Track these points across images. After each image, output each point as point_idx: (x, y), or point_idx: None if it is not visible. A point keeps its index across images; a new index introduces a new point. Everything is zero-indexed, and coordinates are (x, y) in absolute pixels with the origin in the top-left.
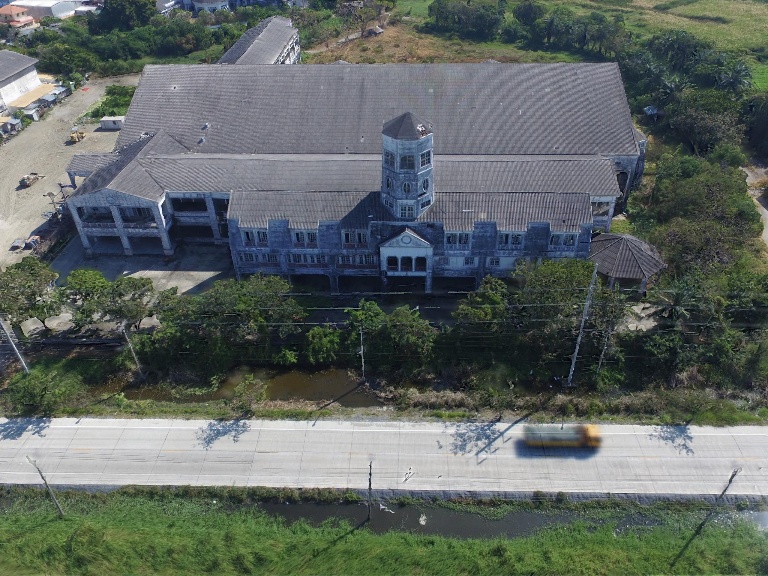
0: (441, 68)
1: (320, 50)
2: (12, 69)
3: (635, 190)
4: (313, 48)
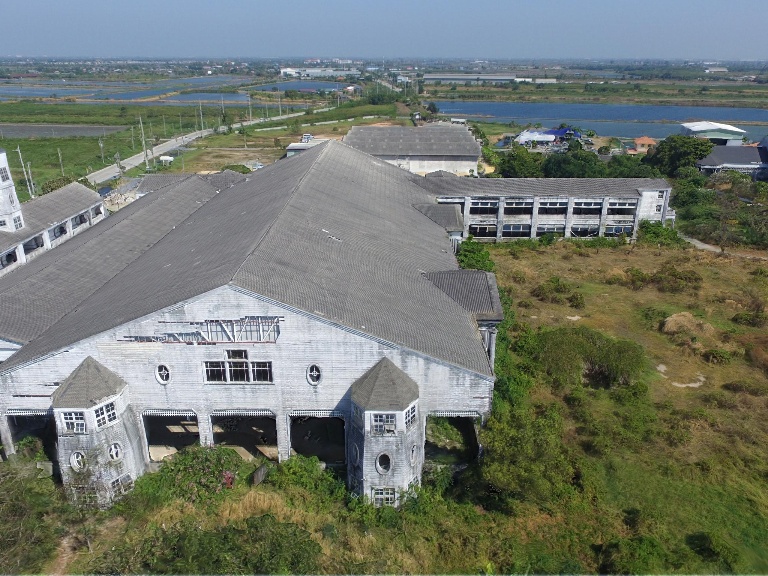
0: (282, 199)
1: (725, 251)
2: (450, 152)
3: (64, 498)
4: (729, 247)
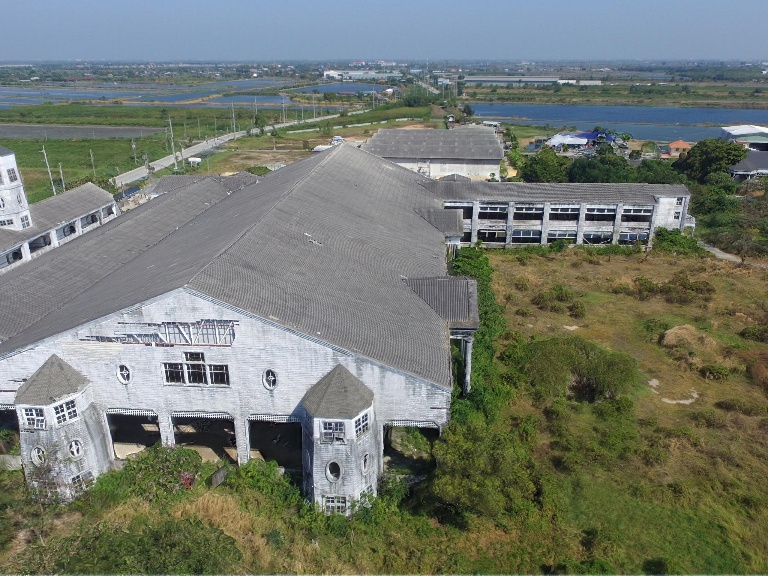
0: (272, 202)
1: (747, 261)
2: (472, 155)
3: None
4: (752, 257)
